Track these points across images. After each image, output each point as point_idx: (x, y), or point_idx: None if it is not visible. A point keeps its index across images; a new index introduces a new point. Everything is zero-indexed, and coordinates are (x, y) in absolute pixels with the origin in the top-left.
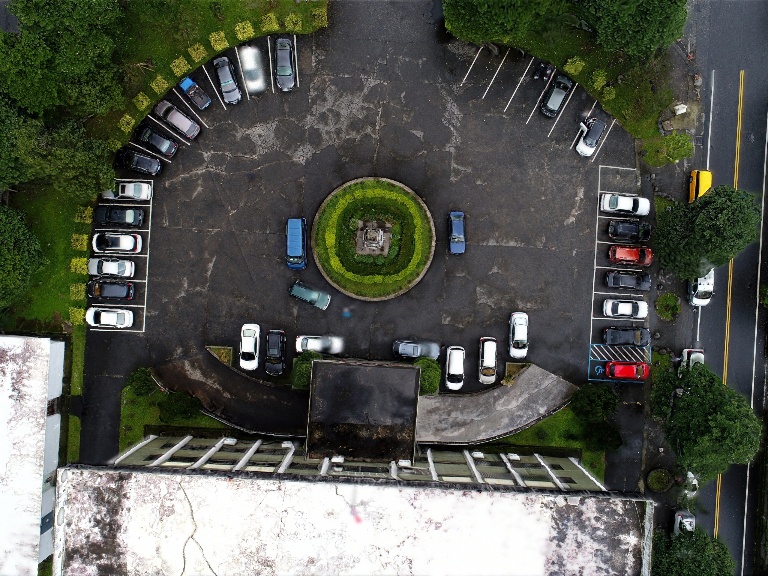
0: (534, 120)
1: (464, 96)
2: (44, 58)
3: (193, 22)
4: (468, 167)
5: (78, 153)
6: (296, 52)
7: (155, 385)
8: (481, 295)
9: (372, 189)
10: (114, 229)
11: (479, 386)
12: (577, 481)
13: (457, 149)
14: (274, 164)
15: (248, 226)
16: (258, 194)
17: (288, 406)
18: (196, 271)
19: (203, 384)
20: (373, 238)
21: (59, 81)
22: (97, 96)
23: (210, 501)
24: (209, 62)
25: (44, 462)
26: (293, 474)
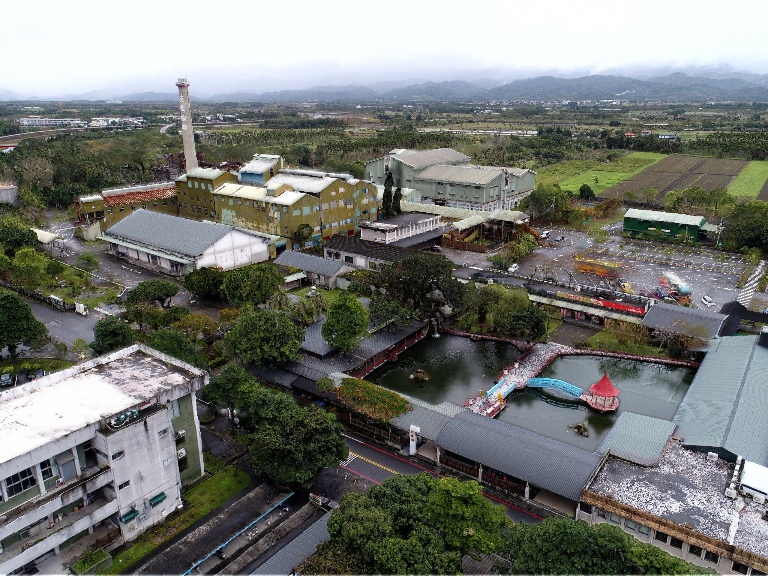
0: None
1: None
2: None
3: None
4: None
5: None
6: None
7: None
8: None
9: None
10: None
11: None
12: None
13: None
14: None
15: None
16: None
17: None
18: None
19: None
20: None
21: None
22: None
23: None
24: None
25: None
26: None
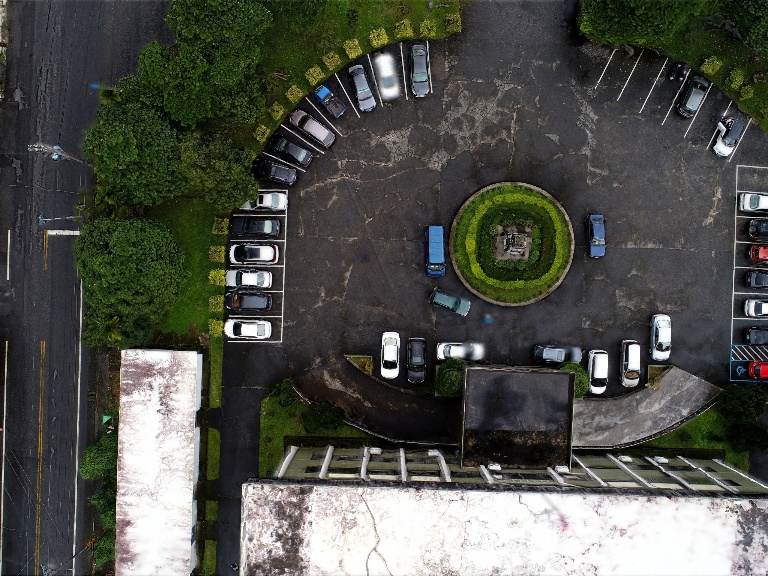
0: (670, 121)
1: (599, 98)
2: (202, 70)
3: (334, 30)
4: (604, 170)
5: (234, 165)
6: (429, 58)
7: (297, 396)
8: (621, 298)
9: (511, 194)
10: (249, 240)
11: (620, 389)
12: (741, 483)
13: (593, 152)
14: (409, 171)
15: (384, 234)
16: (394, 201)
17: (431, 414)
18: (333, 280)
19: (343, 394)
20: (520, 243)
21: (211, 93)
22: (246, 107)
23: (393, 513)
24: (341, 70)
25: (193, 476)
26: (473, 484)
